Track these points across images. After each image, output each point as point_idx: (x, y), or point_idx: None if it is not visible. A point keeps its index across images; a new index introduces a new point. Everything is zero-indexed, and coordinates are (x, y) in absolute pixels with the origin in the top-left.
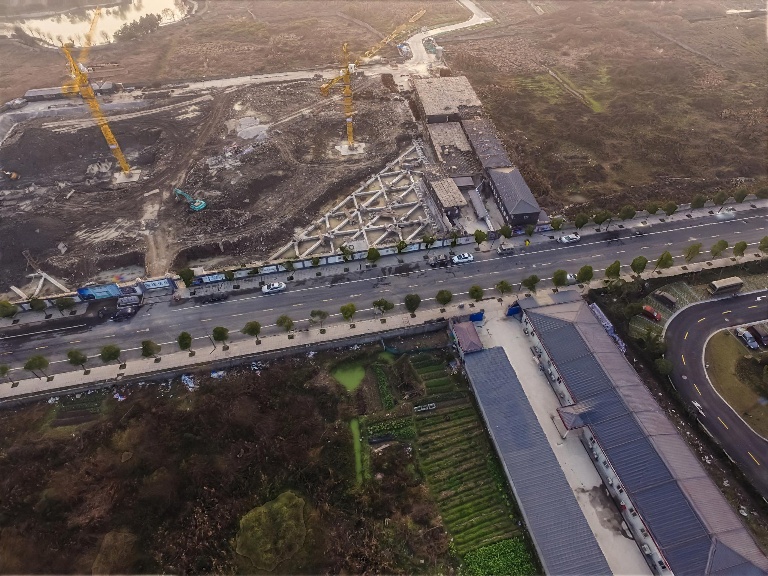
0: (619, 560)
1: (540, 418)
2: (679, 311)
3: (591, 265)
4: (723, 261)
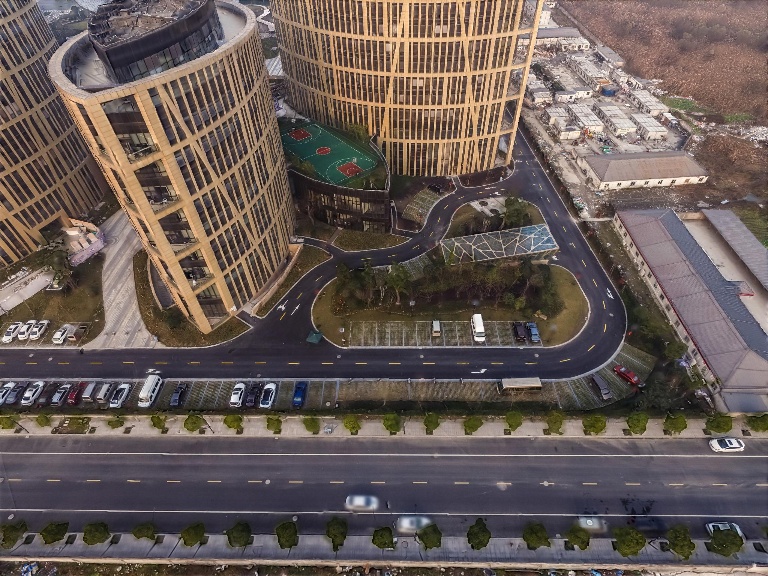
0: (697, 239)
1: (756, 307)
2: (586, 374)
3: (688, 468)
4: (485, 432)
